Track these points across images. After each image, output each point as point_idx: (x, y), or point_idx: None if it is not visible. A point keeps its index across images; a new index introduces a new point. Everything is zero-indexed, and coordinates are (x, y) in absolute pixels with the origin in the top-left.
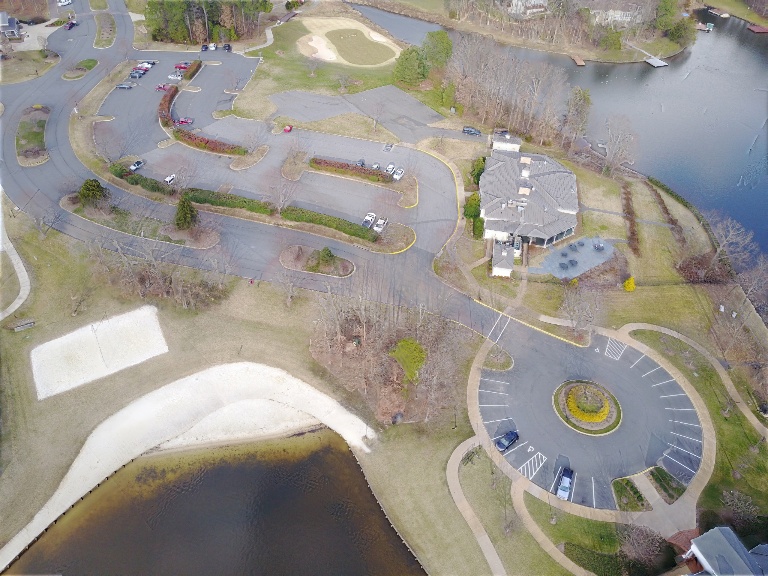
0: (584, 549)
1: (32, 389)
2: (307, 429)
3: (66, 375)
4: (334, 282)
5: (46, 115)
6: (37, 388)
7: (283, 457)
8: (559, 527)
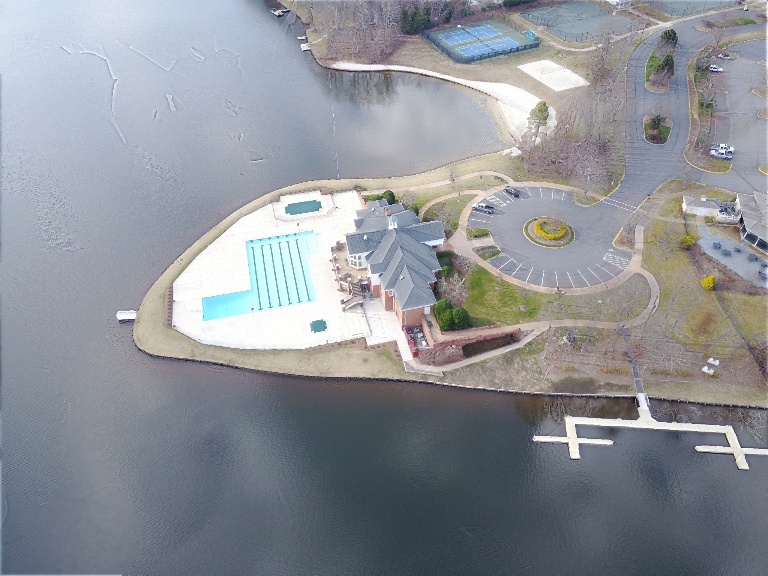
0: (442, 207)
1: (522, 64)
2: (516, 138)
3: (533, 69)
4: (638, 136)
5: (763, 22)
6: (523, 65)
7: (497, 133)
8: (455, 202)
